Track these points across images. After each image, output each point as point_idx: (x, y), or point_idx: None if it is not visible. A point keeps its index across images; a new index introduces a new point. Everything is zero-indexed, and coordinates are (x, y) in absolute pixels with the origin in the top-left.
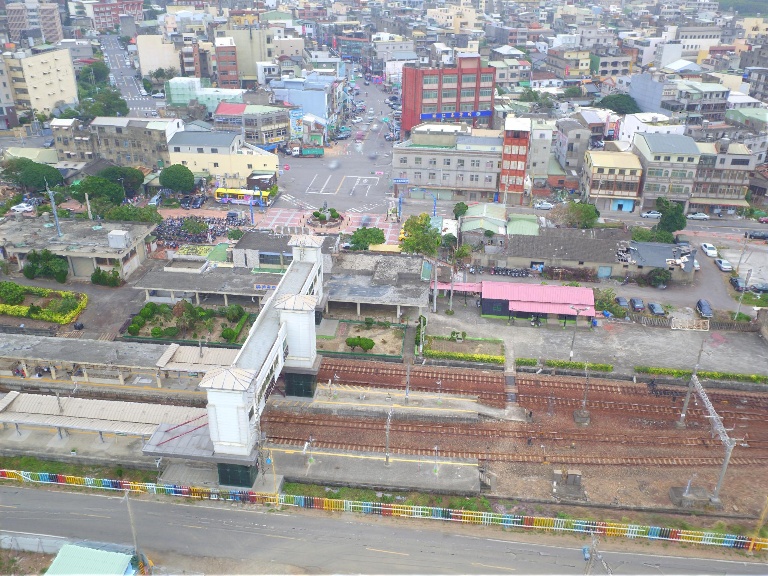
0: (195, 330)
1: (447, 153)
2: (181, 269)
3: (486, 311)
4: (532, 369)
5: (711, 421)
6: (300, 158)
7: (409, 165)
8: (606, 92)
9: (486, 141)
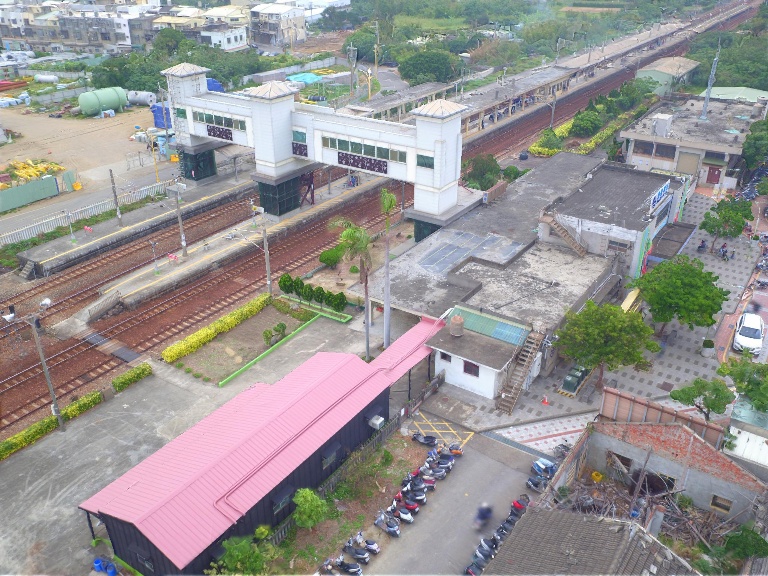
0: None
1: None
2: None
3: None
4: None
5: None
6: None
7: None
8: None
9: None
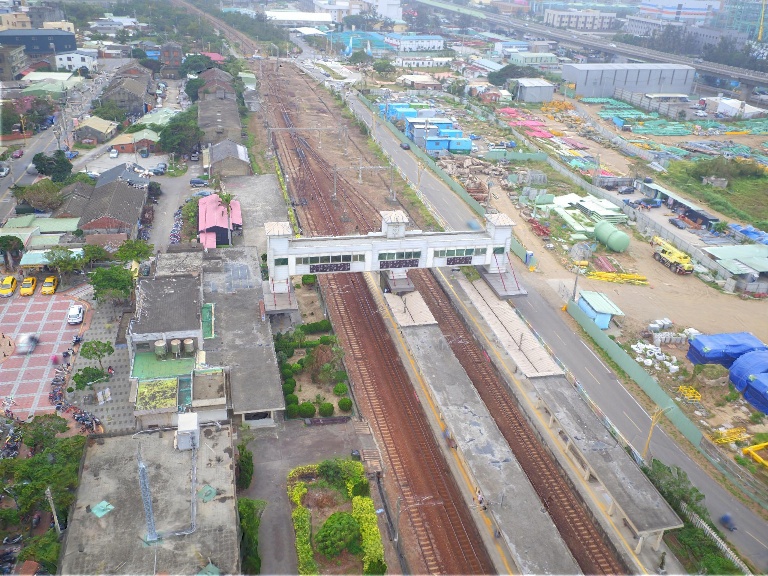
0: None
1: None
2: None
3: None
4: None
5: (369, 172)
6: None
7: None
8: None
9: None
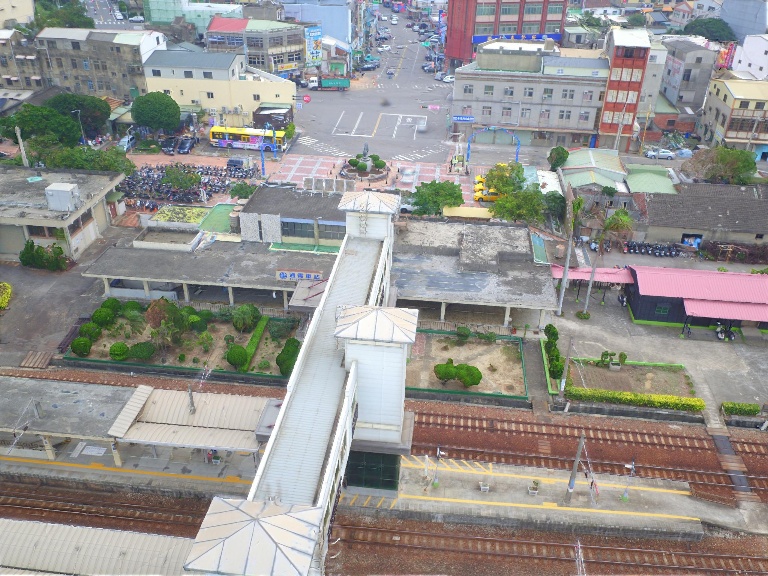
0: (182, 346)
1: (530, 79)
2: (160, 244)
3: (643, 314)
4: (751, 421)
5: None
6: (319, 91)
7: (476, 96)
8: (685, 18)
9: (585, 62)
